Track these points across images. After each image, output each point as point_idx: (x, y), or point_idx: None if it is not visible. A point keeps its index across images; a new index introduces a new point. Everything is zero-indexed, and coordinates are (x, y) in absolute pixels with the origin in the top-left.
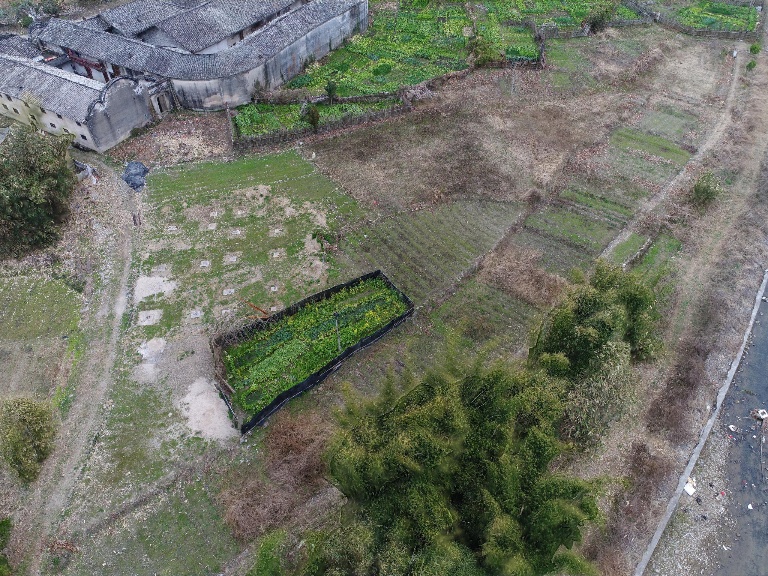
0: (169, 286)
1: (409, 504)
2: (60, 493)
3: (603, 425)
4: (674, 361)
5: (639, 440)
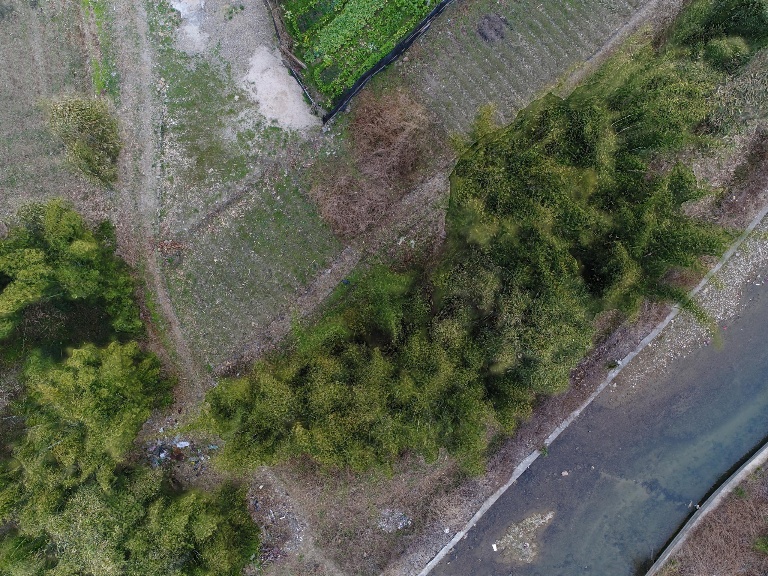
0: None
1: (539, 259)
2: (148, 193)
3: (742, 124)
4: None
5: None
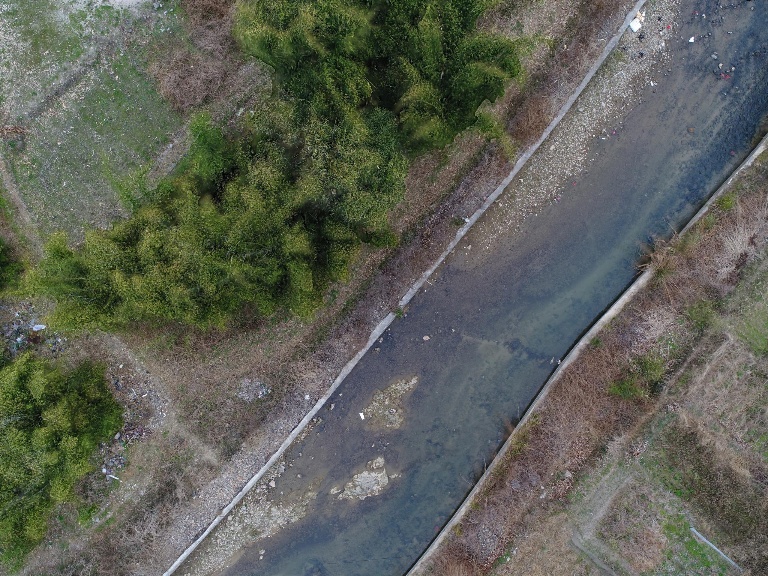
0: None
1: (326, 79)
2: None
3: None
4: None
5: None
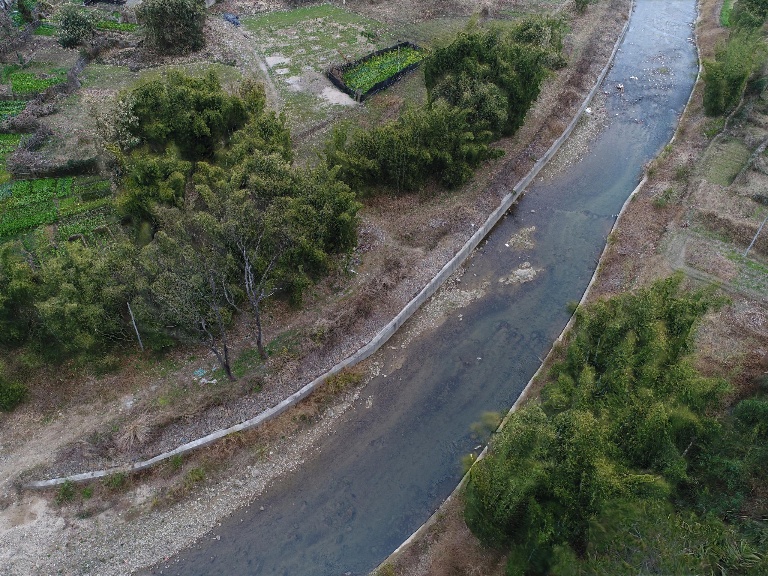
0: (286, 59)
1: None
2: None
3: None
4: (574, 69)
5: (561, 93)
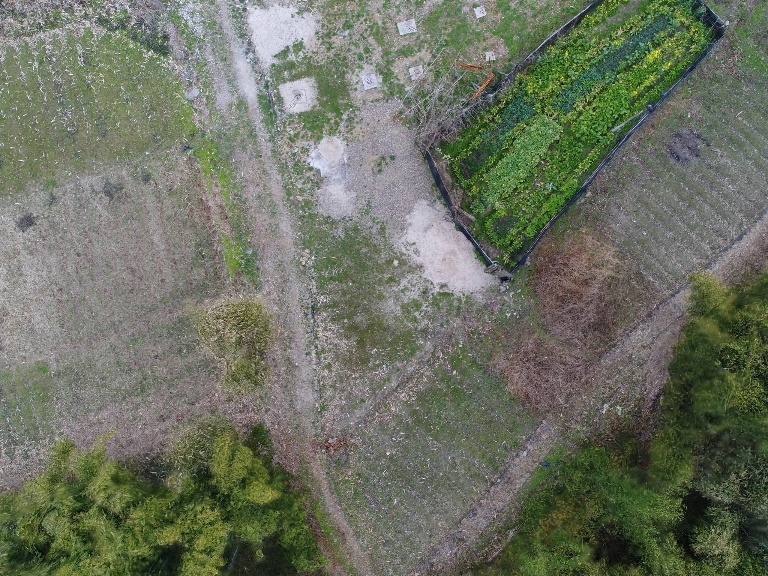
0: (305, 26)
1: None
2: (304, 387)
3: None
4: None
5: None
